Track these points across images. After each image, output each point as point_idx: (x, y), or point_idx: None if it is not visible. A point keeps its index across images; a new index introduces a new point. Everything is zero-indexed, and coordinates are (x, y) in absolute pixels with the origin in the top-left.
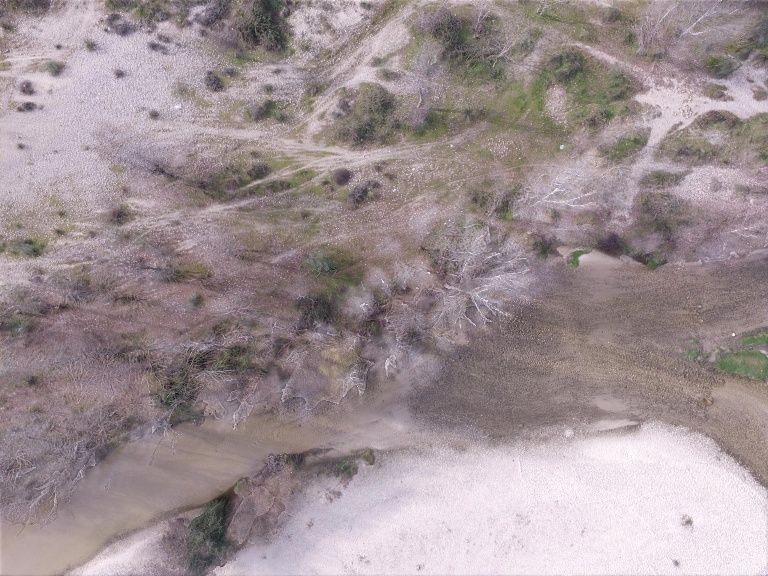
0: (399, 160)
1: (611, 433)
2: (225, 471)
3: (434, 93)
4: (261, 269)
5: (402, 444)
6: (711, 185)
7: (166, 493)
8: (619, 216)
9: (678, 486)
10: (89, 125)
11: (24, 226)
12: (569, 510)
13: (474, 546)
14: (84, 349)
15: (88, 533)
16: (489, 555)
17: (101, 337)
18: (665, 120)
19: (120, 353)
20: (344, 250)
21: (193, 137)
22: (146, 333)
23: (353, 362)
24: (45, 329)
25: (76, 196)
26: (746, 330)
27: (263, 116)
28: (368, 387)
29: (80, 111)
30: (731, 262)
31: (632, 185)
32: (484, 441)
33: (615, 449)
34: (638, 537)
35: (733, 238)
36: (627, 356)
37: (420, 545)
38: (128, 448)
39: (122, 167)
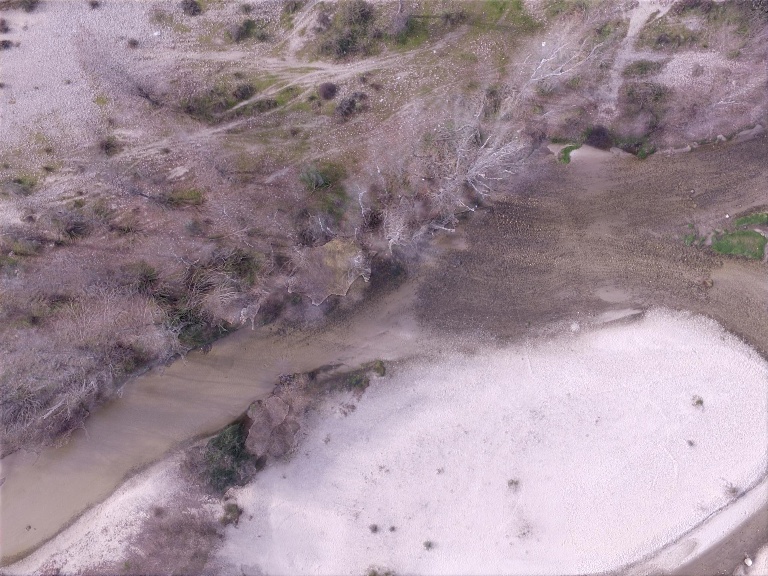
0: (384, 70)
1: (616, 323)
2: (237, 396)
3: (413, 0)
4: (255, 190)
5: (411, 353)
6: (693, 70)
7: (179, 423)
8: (606, 109)
9: (686, 368)
10: (68, 59)
11: (11, 166)
12: (581, 401)
13: (491, 445)
14: (83, 285)
15: (104, 470)
16: (507, 453)
17: (99, 271)
18: (643, 9)
19: (120, 286)
20: (337, 164)
21: (175, 63)
22: (145, 264)
23: (356, 252)
24: (42, 269)
25: (61, 132)
26: (739, 211)
27: (244, 36)
28: (372, 300)
29: (58, 45)
30: (719, 145)
31: (616, 76)
32: (492, 343)
33: (621, 338)
34: (651, 421)
35: (719, 121)
36: (625, 246)
37: (438, 449)
38: (137, 382)
39: (106, 99)
